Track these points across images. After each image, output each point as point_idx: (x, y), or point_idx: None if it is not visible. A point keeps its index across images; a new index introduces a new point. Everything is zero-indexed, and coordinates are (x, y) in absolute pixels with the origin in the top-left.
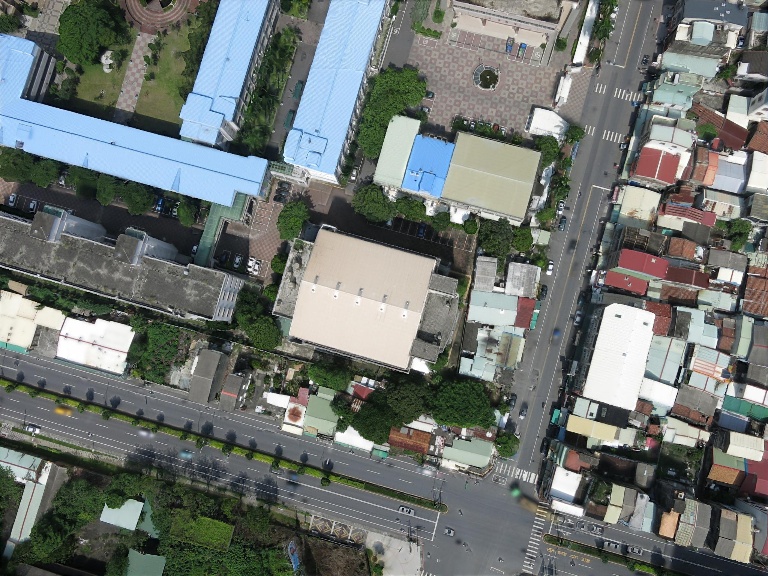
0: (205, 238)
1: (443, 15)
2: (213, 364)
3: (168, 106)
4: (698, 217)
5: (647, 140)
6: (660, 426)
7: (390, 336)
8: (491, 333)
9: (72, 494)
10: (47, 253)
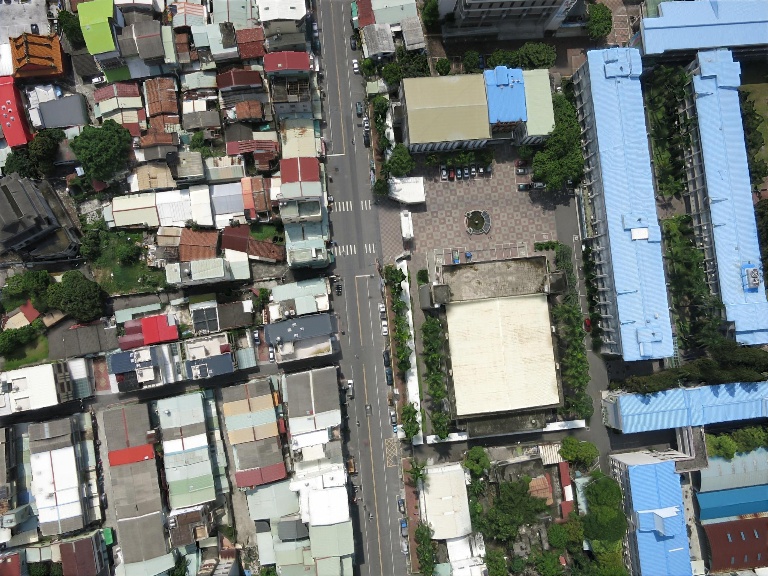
0: None
1: None
2: None
3: None
4: (244, 146)
5: None
6: None
7: None
8: None
9: None
10: None
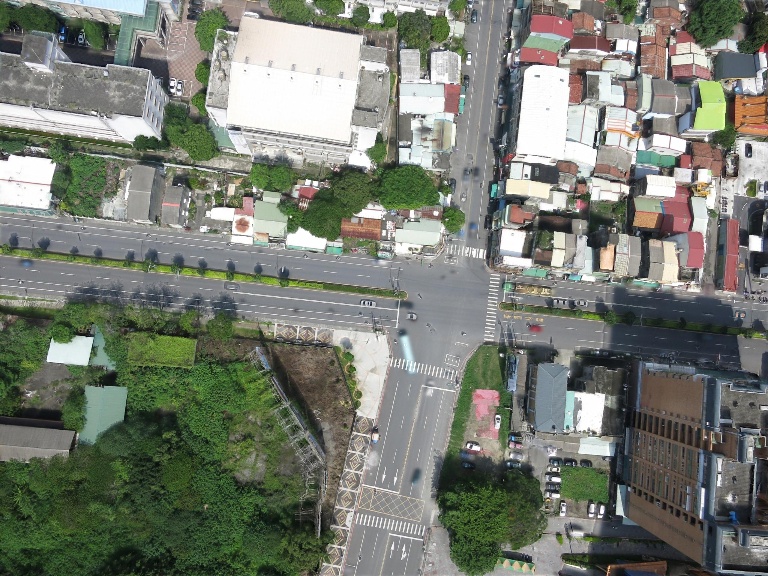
0: (120, 51)
1: None
2: (149, 177)
3: None
4: None
5: None
6: (587, 185)
7: (329, 109)
8: (423, 123)
9: (10, 340)
10: None
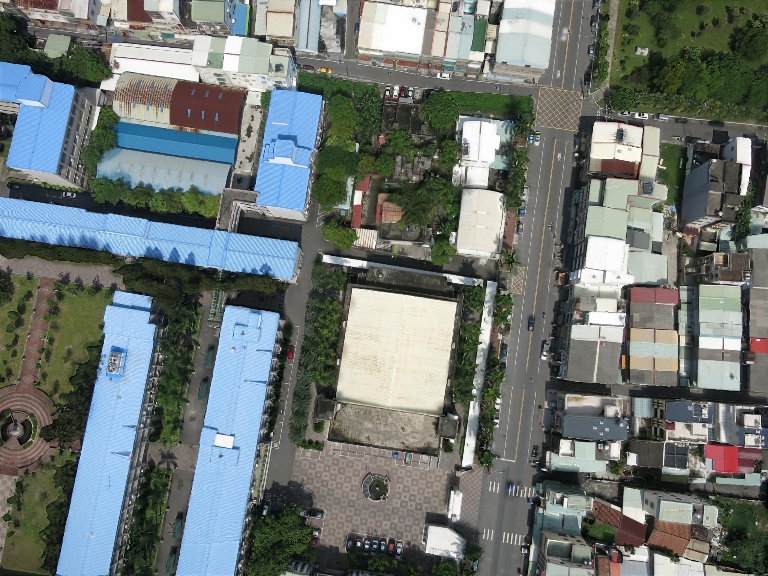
0: None
1: (323, 423)
2: None
3: (37, 556)
4: None
5: (544, 570)
6: None
7: None
8: None
9: None
10: None
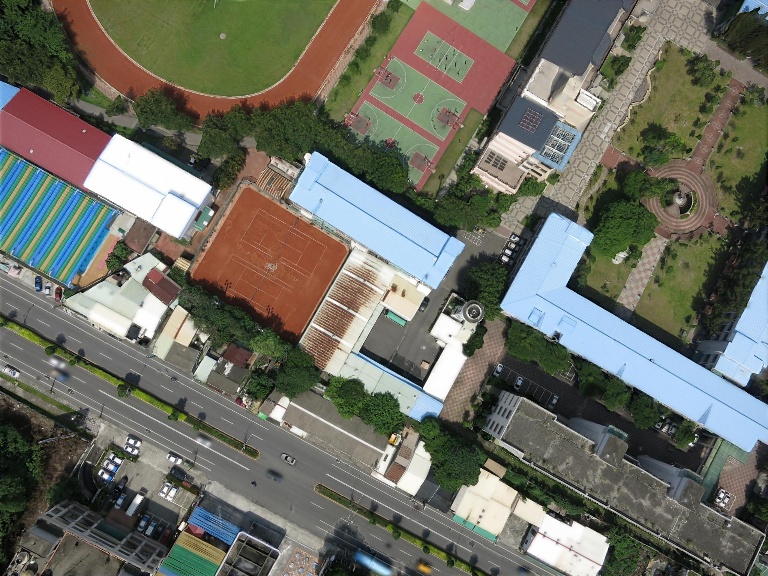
0: (713, 474)
1: None
2: None
3: (667, 314)
4: None
5: None
6: None
7: None
8: None
9: None
10: (594, 470)
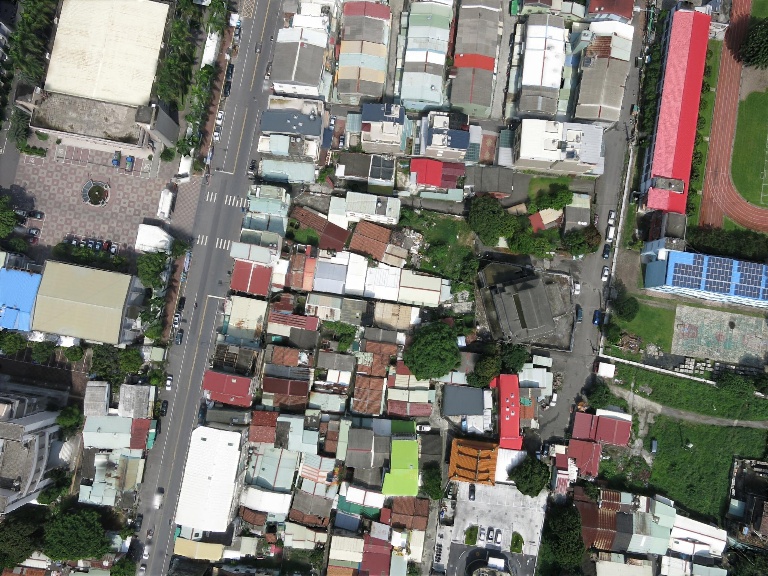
0: None
1: None
2: None
3: None
4: (301, 323)
5: None
6: (277, 533)
7: None
8: (110, 457)
9: None
10: None
